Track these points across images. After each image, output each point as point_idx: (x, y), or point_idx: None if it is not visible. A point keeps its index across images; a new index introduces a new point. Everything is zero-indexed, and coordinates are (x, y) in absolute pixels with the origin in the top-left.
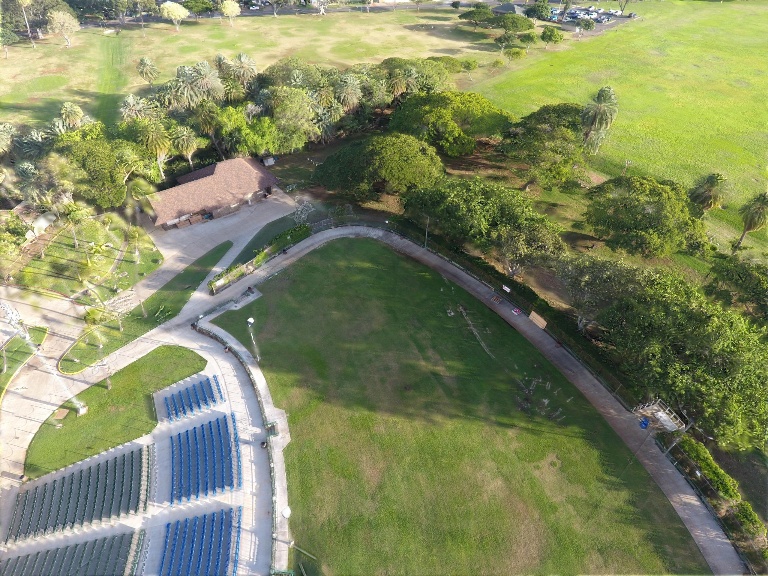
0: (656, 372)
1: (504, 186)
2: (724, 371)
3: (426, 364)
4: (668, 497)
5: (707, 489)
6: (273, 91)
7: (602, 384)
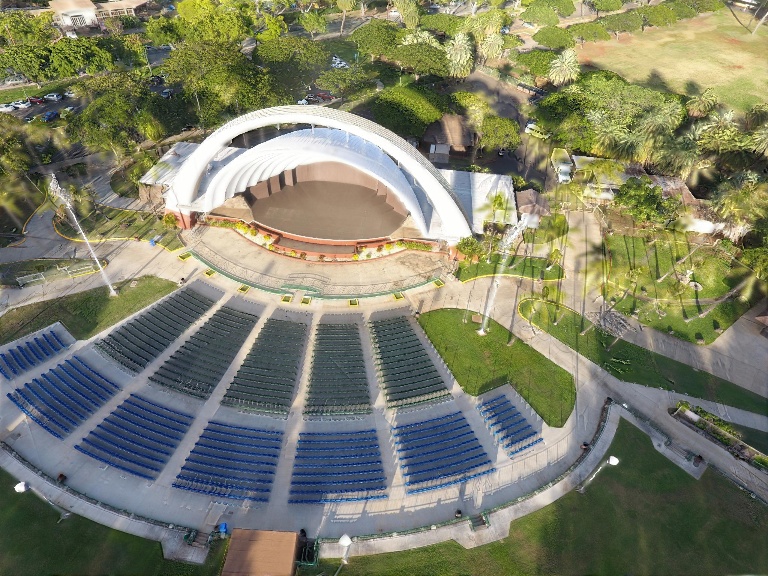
0: None
1: None
2: None
3: None
4: None
5: None
6: None
7: None
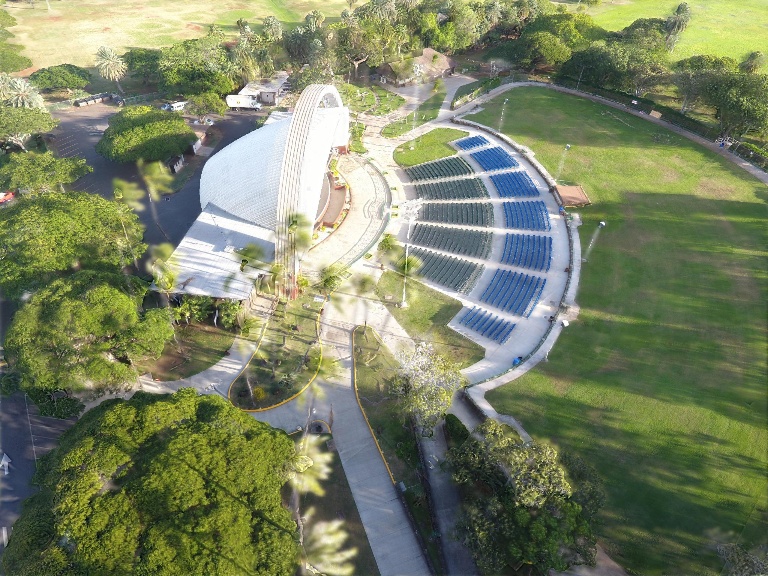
0: (734, 101)
1: None
2: (767, 101)
3: (597, 130)
4: (737, 164)
5: (756, 158)
6: (452, 6)
7: (697, 135)
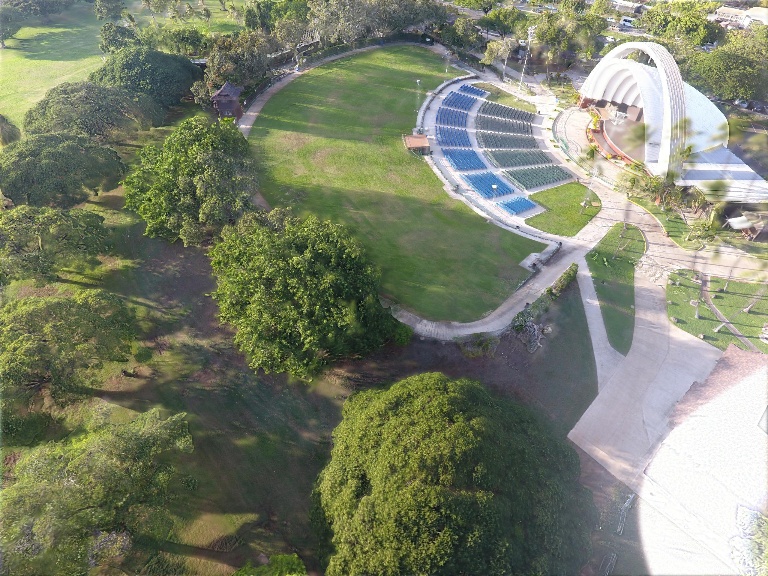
0: None
1: (176, 555)
2: None
3: (363, 213)
4: None
5: None
6: None
7: None
